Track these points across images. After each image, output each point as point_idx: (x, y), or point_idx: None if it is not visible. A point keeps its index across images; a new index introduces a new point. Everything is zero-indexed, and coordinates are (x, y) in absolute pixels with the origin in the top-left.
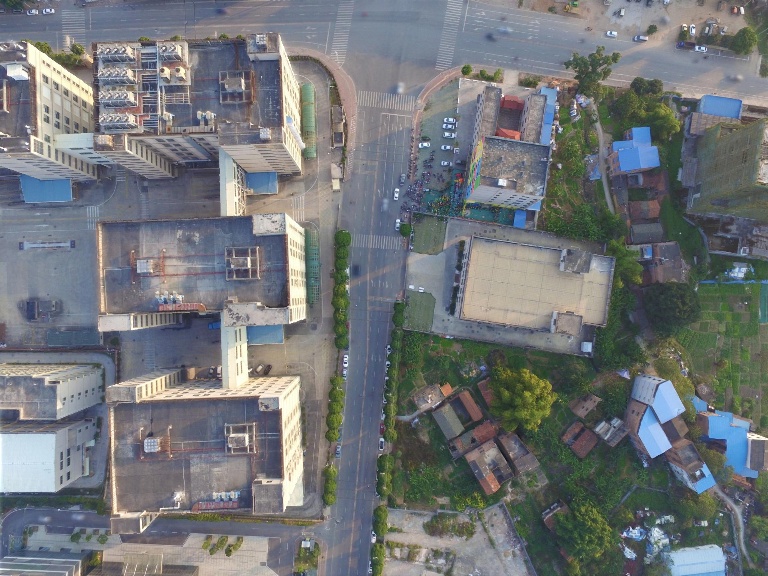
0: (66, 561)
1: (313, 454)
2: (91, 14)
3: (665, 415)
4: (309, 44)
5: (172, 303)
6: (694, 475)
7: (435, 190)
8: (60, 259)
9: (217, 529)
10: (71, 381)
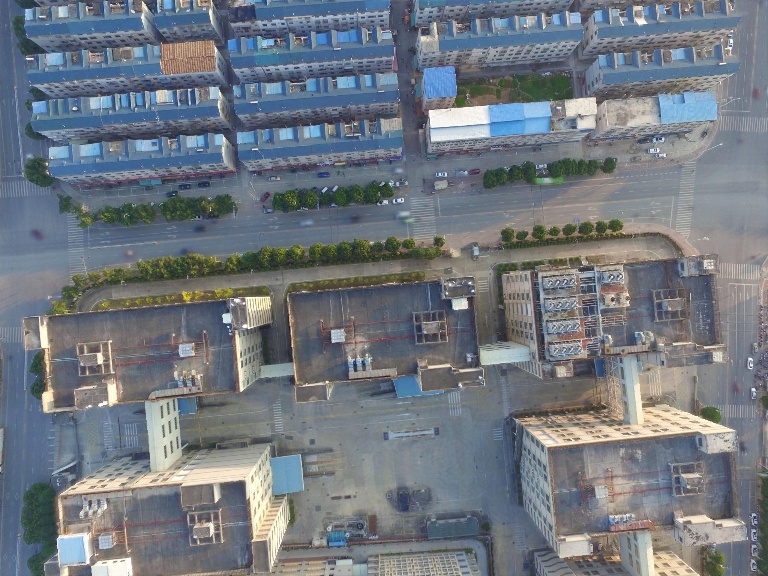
0: None
1: None
2: (439, 201)
3: None
4: (654, 219)
5: (623, 522)
6: None
7: None
8: (425, 447)
9: None
10: None
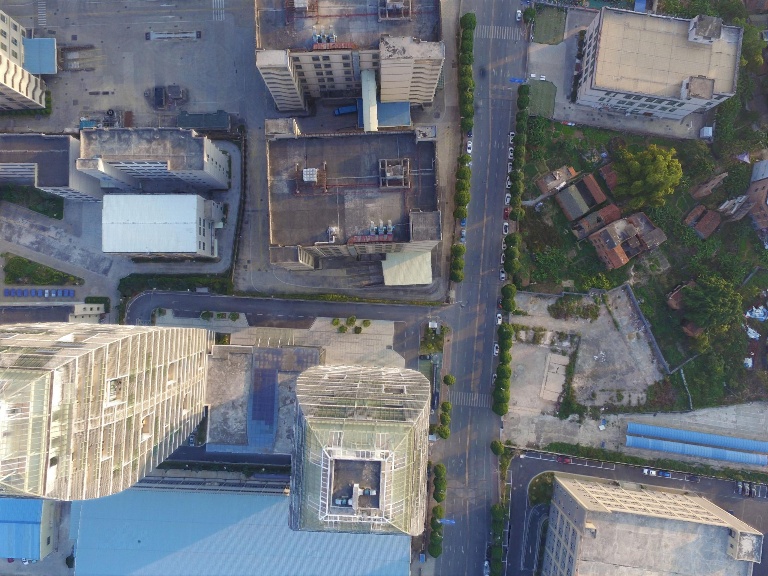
0: None
1: None
2: None
3: None
4: None
5: (326, 42)
6: None
7: None
8: (186, 49)
9: (343, 313)
10: (211, 144)
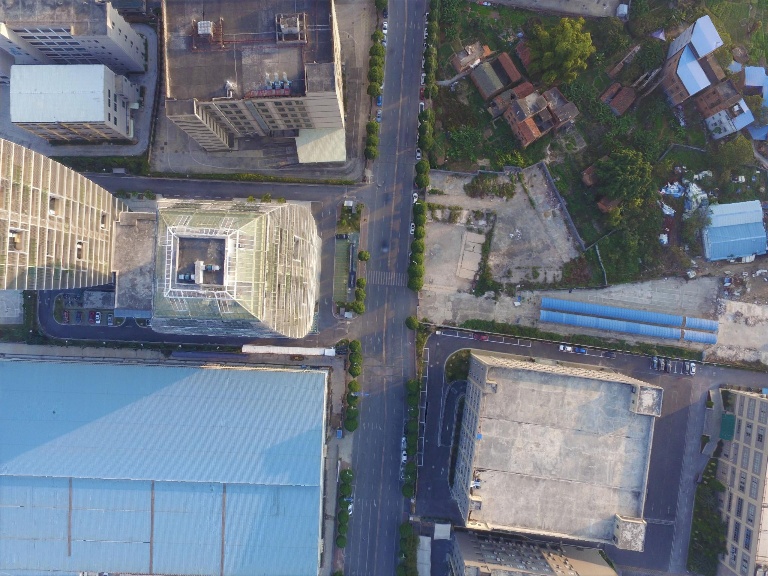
0: None
1: (354, 120)
2: None
3: (703, 48)
4: None
5: None
6: (732, 112)
7: None
8: None
9: (260, 194)
10: None
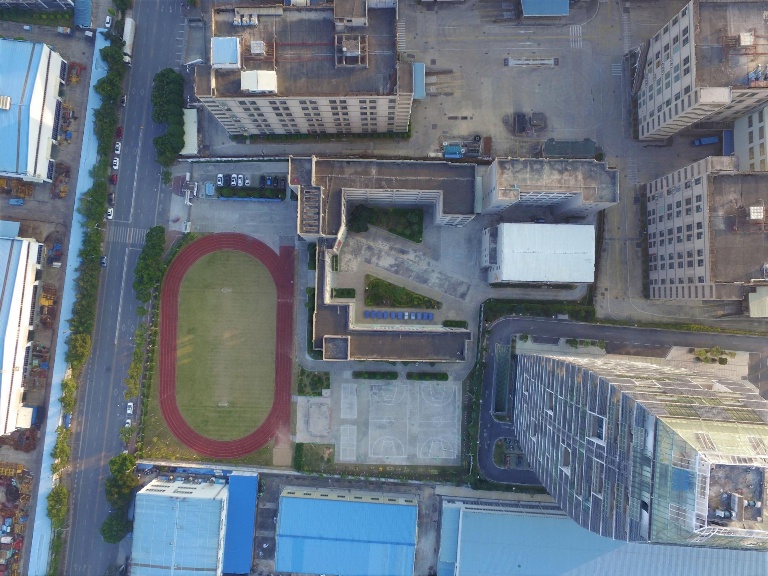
0: None
1: None
2: None
3: None
4: None
5: (763, 80)
6: None
7: None
8: (544, 76)
9: (699, 343)
10: None
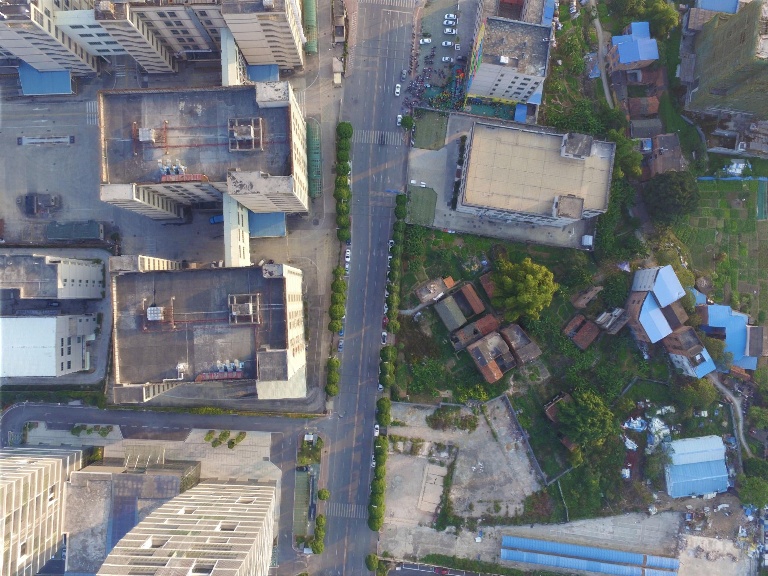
0: (67, 450)
1: (315, 349)
2: None
3: (666, 299)
4: None
5: (175, 174)
6: (694, 360)
7: (436, 86)
8: (59, 154)
9: (219, 424)
10: (72, 265)
